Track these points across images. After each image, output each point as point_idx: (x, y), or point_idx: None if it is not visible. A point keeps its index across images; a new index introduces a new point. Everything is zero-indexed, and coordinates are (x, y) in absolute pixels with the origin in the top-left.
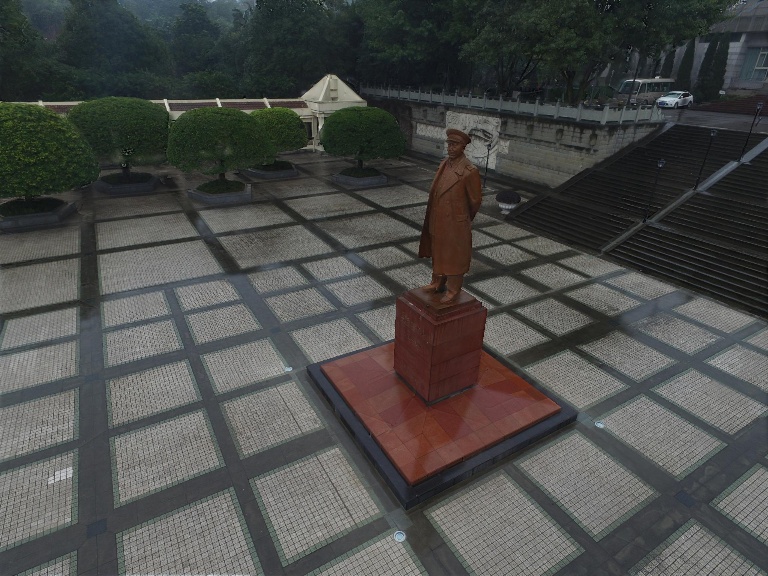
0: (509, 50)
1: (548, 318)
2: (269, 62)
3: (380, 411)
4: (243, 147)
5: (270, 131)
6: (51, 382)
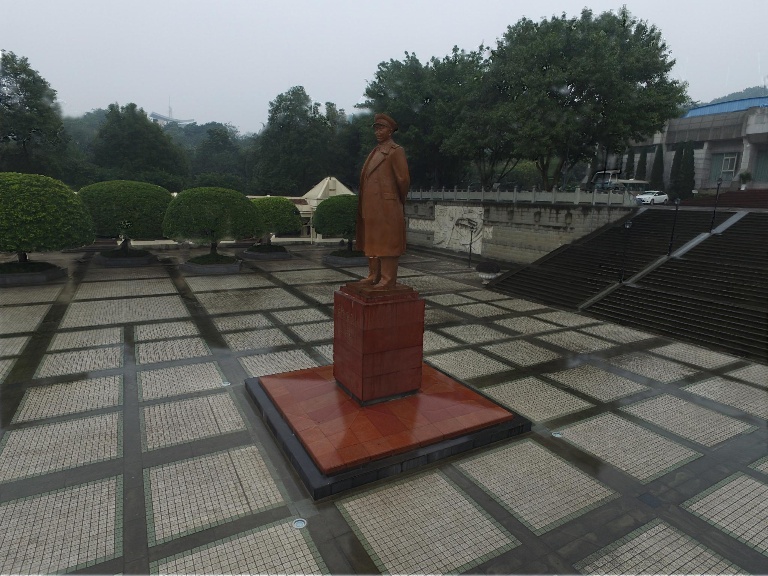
0: (484, 142)
1: (515, 353)
2: (275, 167)
3: (309, 411)
4: (234, 220)
5: (265, 215)
6: None
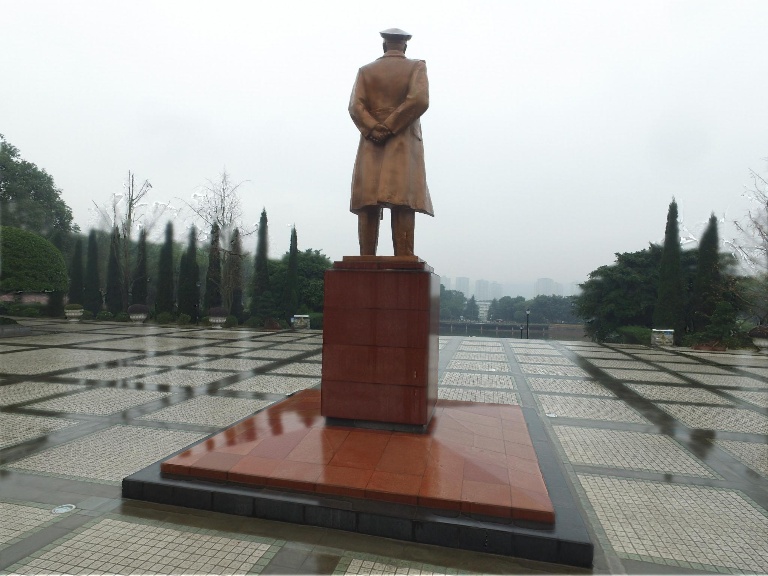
0: None
1: None
2: None
3: None
4: None
5: None
6: (610, 375)
